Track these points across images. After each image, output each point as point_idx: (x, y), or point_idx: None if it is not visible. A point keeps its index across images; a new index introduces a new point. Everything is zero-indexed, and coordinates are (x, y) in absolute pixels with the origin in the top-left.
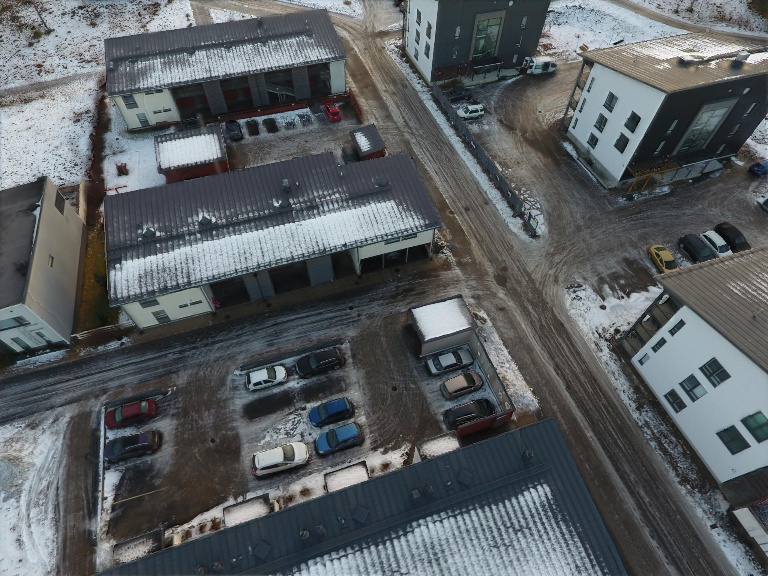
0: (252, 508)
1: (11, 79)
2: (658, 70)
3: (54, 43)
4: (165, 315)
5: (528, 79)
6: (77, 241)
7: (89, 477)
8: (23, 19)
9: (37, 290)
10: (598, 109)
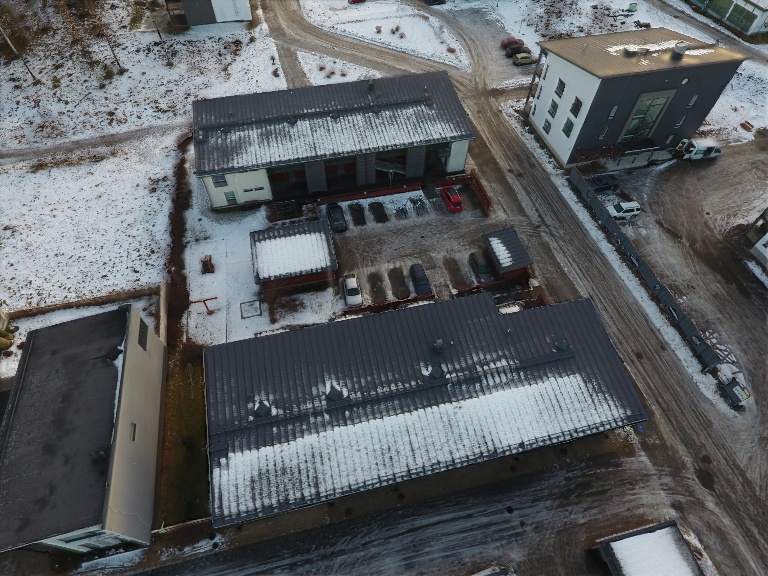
0: None
1: (80, 128)
2: None
3: (127, 86)
4: None
5: (684, 165)
6: (158, 376)
7: None
8: (95, 55)
9: (118, 492)
10: None
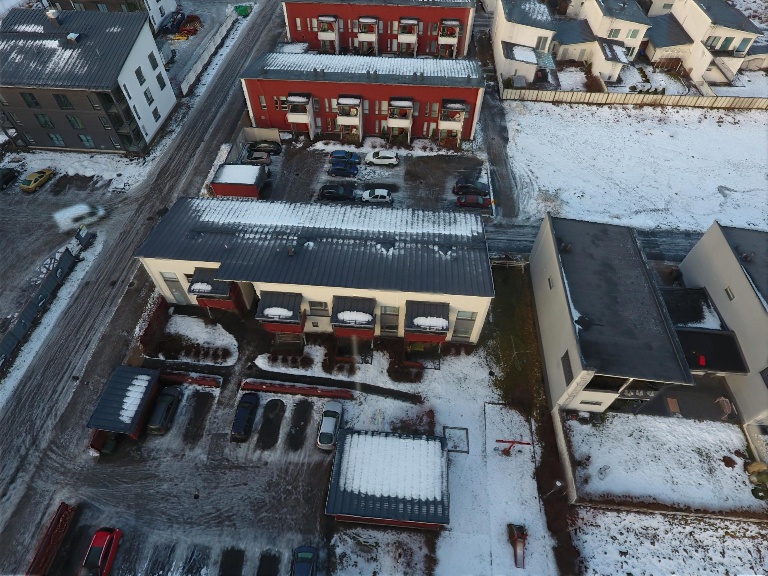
0: (398, 104)
1: None
2: None
3: None
4: None
5: None
6: None
7: (498, 185)
8: None
9: (547, 238)
10: None
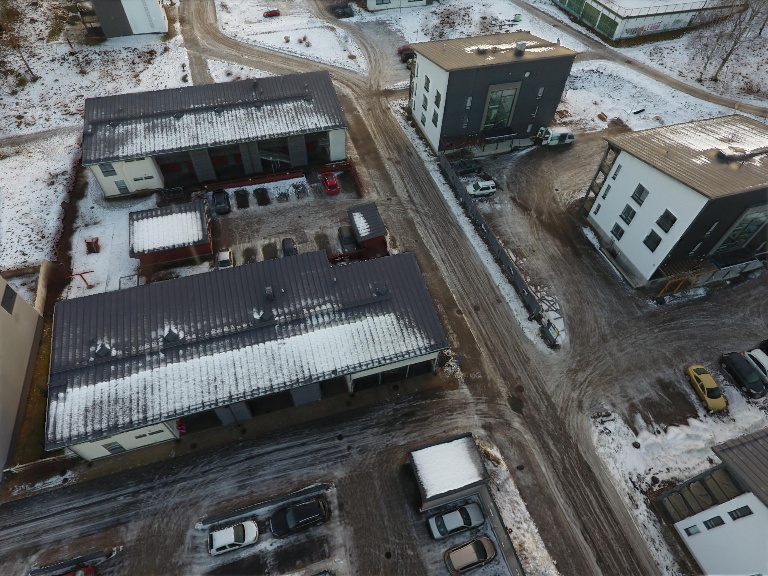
0: None
1: None
2: (696, 166)
3: (39, 92)
4: (119, 445)
5: (543, 151)
6: (28, 340)
7: None
8: (9, 64)
9: None
10: (625, 199)
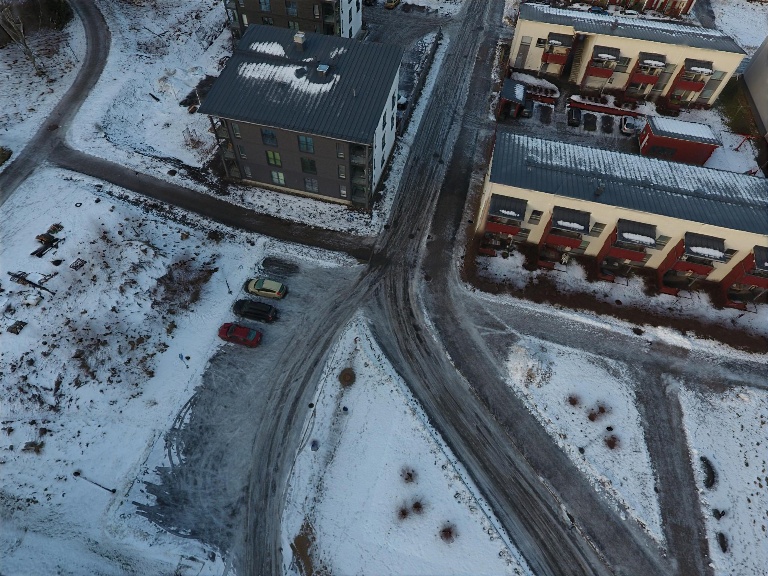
0: None
1: None
2: None
3: None
4: None
5: None
6: None
7: None
8: None
9: None
10: None
